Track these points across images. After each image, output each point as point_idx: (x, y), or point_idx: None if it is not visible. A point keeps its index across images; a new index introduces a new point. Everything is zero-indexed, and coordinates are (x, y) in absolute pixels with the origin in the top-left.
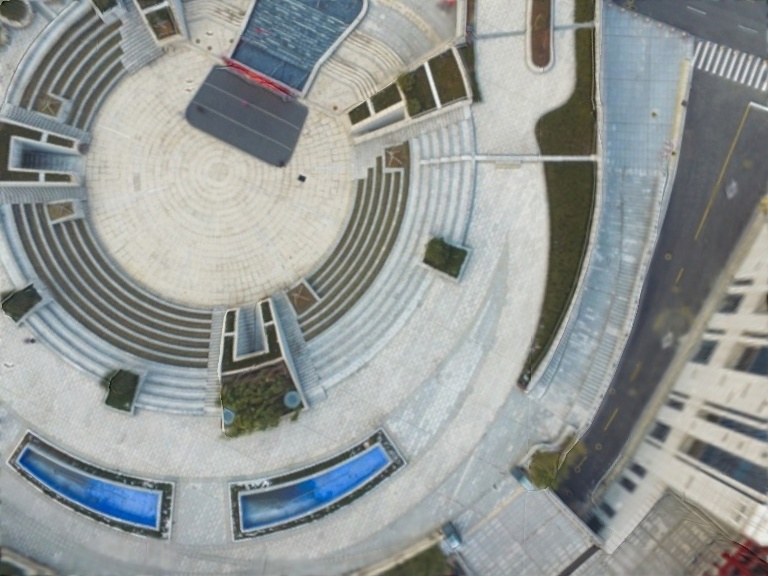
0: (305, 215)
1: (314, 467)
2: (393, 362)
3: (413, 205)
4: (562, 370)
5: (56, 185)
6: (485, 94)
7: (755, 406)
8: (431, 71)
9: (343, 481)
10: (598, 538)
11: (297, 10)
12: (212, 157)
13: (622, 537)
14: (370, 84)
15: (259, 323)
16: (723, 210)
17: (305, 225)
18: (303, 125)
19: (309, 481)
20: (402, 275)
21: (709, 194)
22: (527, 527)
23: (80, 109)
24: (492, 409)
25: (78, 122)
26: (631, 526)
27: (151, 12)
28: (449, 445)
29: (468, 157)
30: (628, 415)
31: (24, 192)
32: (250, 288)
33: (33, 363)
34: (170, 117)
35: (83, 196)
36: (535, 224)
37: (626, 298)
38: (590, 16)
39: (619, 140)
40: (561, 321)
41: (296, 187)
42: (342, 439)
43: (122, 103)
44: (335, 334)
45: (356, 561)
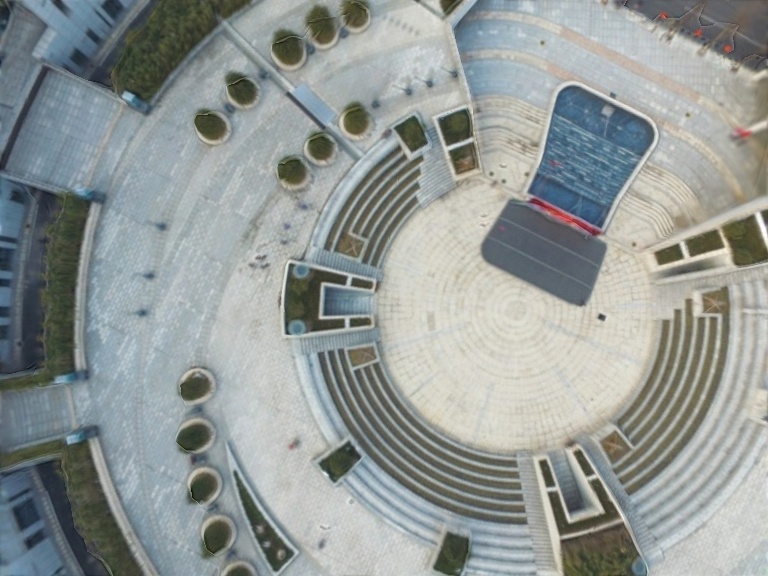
0: (606, 355)
1: None
2: (731, 521)
3: (736, 354)
4: None
5: (359, 330)
6: None
7: None
8: (765, 222)
9: None
10: None
11: (587, 141)
12: (509, 295)
13: None
14: (666, 219)
15: (579, 476)
16: None
17: (606, 366)
18: (602, 262)
19: None
20: (731, 428)
21: None
22: None
23: (375, 246)
24: None
25: (373, 260)
26: None
27: (455, 148)
28: None
29: None
30: None
31: (329, 339)
32: (552, 432)
33: (351, 525)
34: (464, 253)
35: (378, 337)
36: None
37: None
38: None
39: None
40: None
41: (596, 326)
42: None
43: (414, 238)
44: (661, 488)
45: None
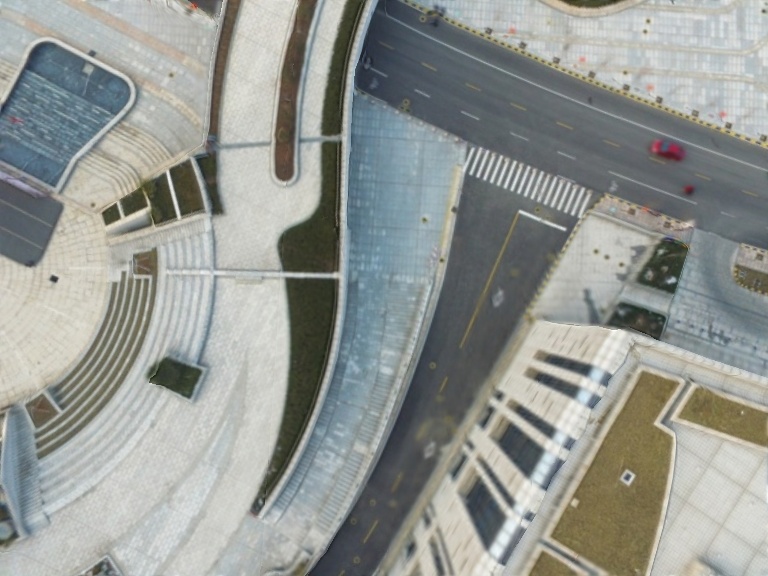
0: (56, 318)
1: None
2: (122, 486)
3: (158, 316)
4: (303, 491)
5: None
6: (227, 206)
7: (454, 550)
8: (172, 180)
9: None
10: None
11: (59, 98)
12: None
13: None
14: (133, 180)
15: None
16: (488, 319)
17: (56, 328)
18: (57, 222)
19: None
20: (140, 391)
21: (475, 302)
22: None
23: None
24: (225, 535)
25: None
26: None
27: None
28: (179, 573)
29: (207, 272)
30: (387, 527)
31: None
32: None
33: None
34: None
35: None
36: (275, 342)
37: (378, 413)
38: (337, 129)
39: (388, 245)
40: (297, 444)
41: (47, 288)
42: (65, 568)
43: None
44: (68, 452)
45: None
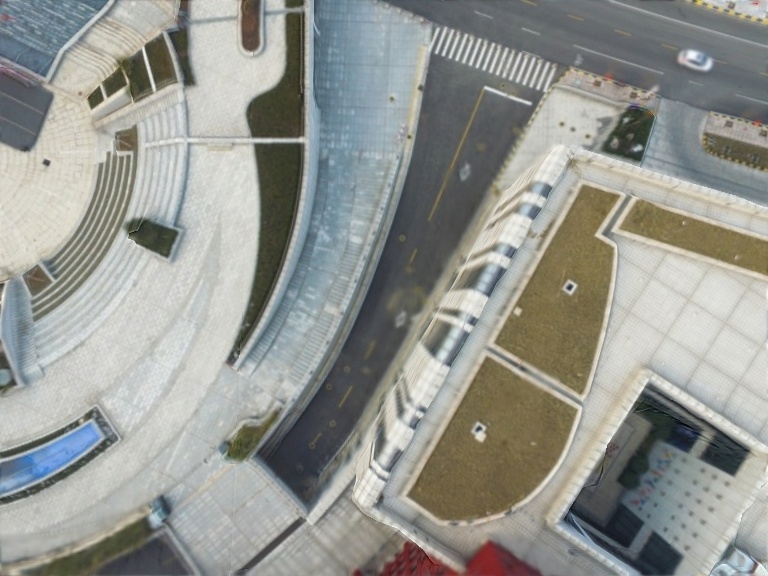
0: (49, 198)
1: (30, 443)
2: (109, 340)
3: (139, 187)
4: (276, 347)
5: None
6: (198, 78)
7: None
8: (147, 55)
9: (59, 457)
10: (304, 510)
11: None
12: None
13: (323, 509)
14: None
15: None
16: (456, 192)
17: (49, 208)
18: (48, 110)
19: (25, 457)
20: (124, 256)
21: (443, 176)
22: (236, 500)
23: None
24: (204, 386)
25: None
26: (332, 498)
27: None
28: (162, 421)
29: (181, 139)
30: (362, 392)
31: None
32: None
33: None
34: None
35: None
36: (246, 205)
37: (347, 277)
38: (300, 1)
39: (357, 124)
40: (268, 299)
41: (41, 171)
42: (58, 416)
43: None
44: (60, 314)
45: (71, 535)
